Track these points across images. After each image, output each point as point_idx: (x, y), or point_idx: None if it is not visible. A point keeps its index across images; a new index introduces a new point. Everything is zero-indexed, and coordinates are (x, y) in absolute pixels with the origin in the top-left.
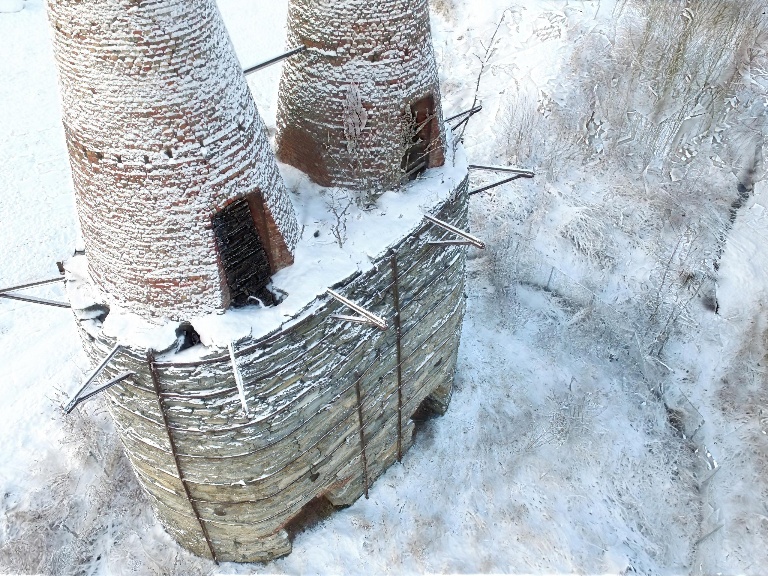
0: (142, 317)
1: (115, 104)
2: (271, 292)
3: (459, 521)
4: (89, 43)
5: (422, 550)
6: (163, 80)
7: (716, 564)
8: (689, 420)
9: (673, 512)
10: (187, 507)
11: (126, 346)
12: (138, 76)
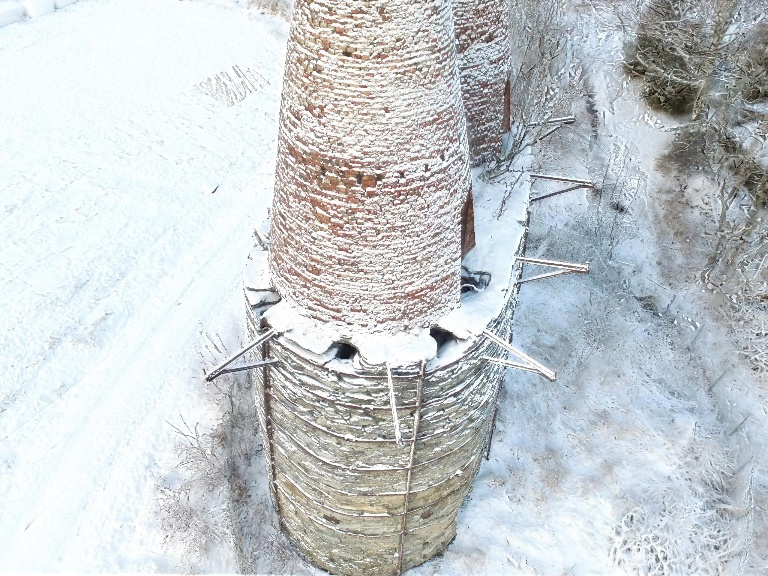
0: (406, 333)
1: (407, 118)
2: (469, 277)
3: (565, 445)
4: (390, 61)
5: (557, 480)
6: (445, 84)
7: (728, 399)
8: (658, 301)
9: (686, 373)
10: (394, 525)
11: (397, 367)
12: (430, 85)
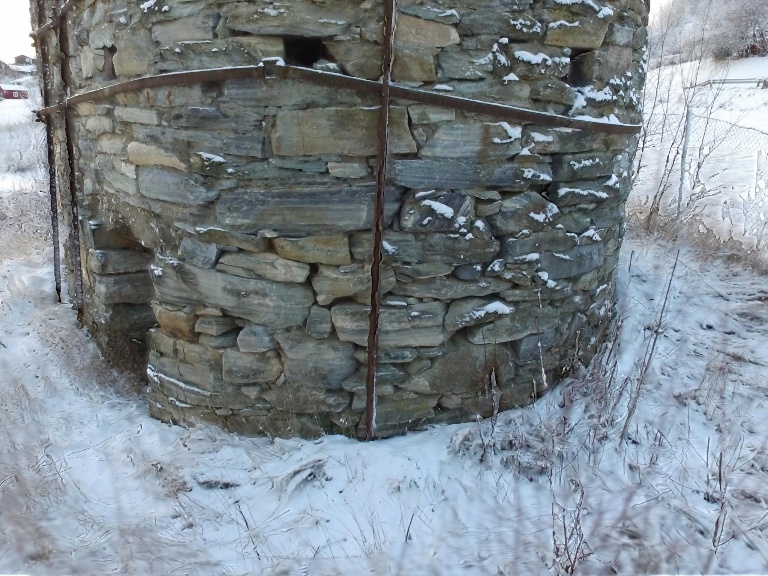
0: None
1: None
2: None
3: None
4: None
5: None
6: None
7: None
8: None
9: None
10: None
11: None
12: None
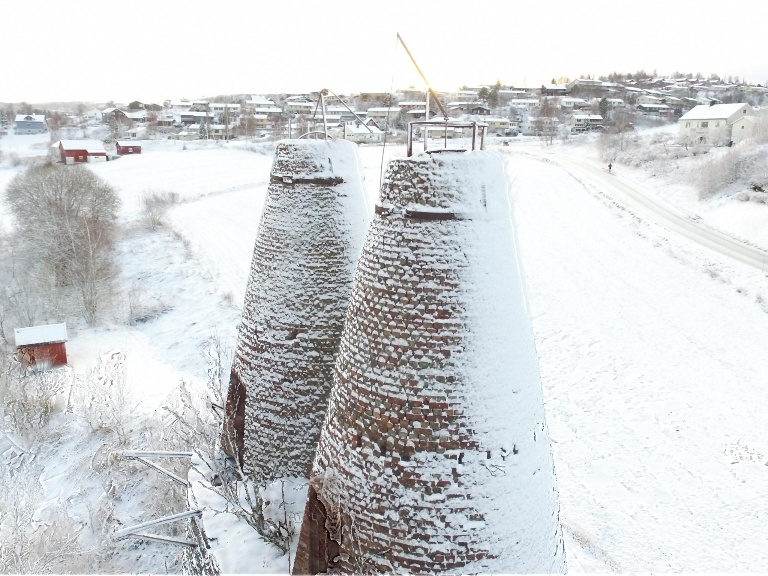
0: None
1: None
2: None
3: None
4: None
5: None
6: None
7: None
8: None
9: None
10: None
11: None
12: None
